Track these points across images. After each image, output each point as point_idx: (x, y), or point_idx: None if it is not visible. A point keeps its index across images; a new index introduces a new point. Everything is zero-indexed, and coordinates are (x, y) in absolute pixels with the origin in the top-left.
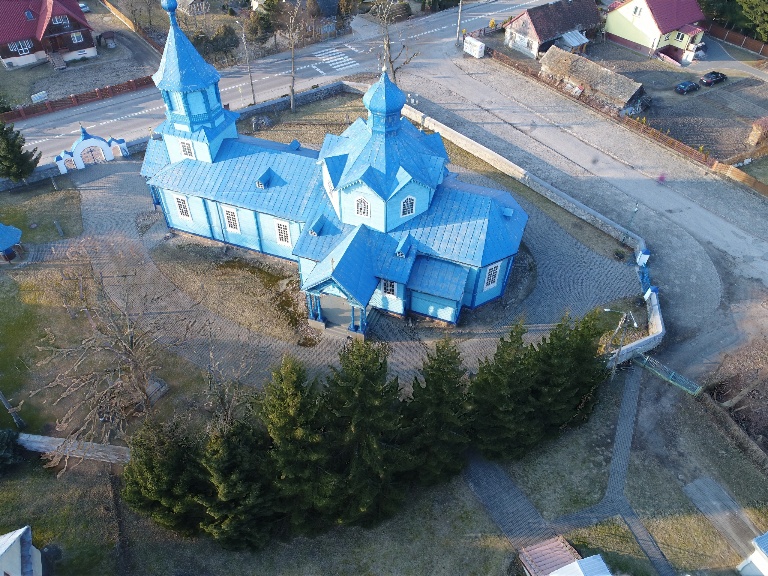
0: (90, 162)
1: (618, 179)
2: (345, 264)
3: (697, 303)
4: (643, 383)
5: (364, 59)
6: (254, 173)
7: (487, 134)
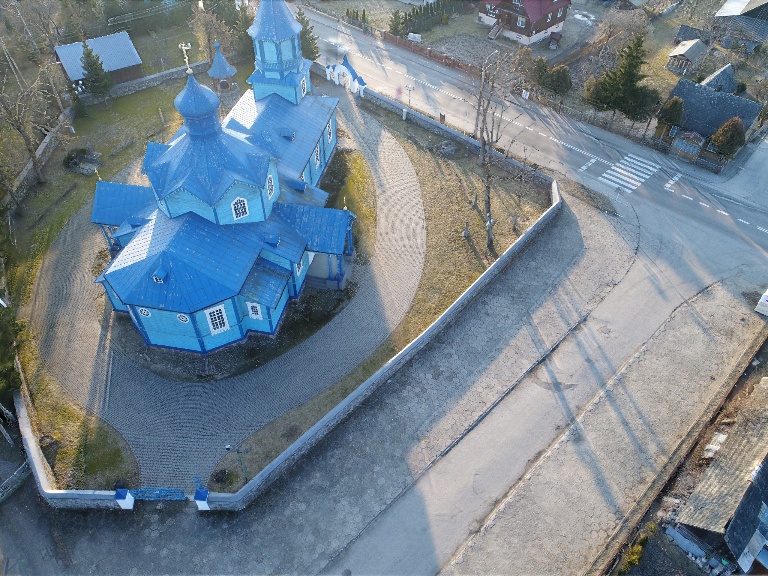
0: (342, 84)
1: (428, 501)
2: (116, 189)
3: (117, 573)
4: (1, 480)
5: (648, 194)
6: None
7: (501, 329)
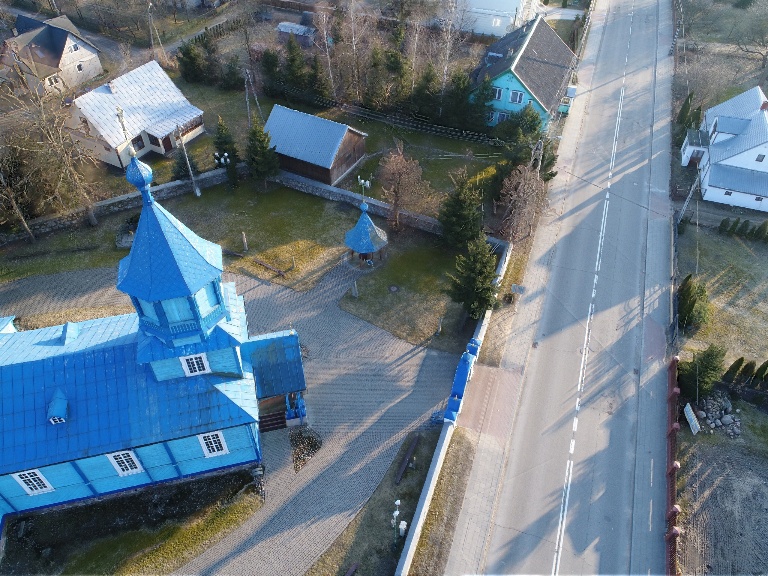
0: None
1: None
2: None
3: None
4: None
5: None
6: (88, 337)
7: None
